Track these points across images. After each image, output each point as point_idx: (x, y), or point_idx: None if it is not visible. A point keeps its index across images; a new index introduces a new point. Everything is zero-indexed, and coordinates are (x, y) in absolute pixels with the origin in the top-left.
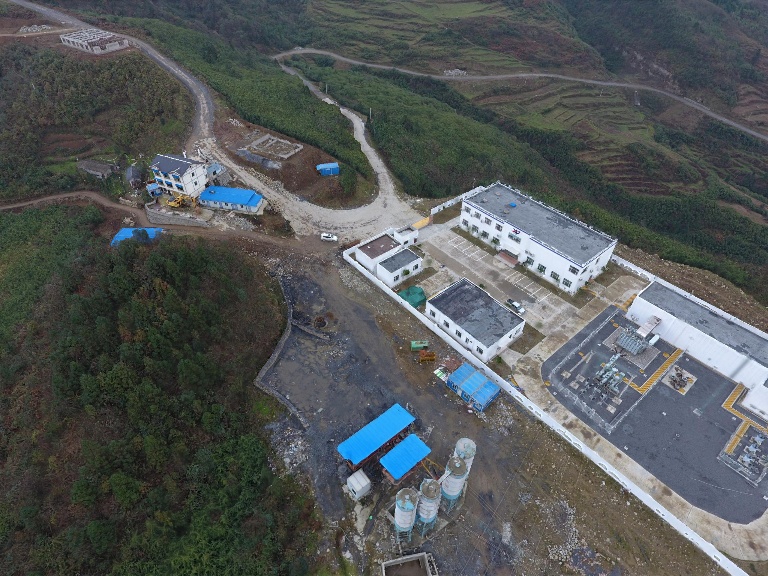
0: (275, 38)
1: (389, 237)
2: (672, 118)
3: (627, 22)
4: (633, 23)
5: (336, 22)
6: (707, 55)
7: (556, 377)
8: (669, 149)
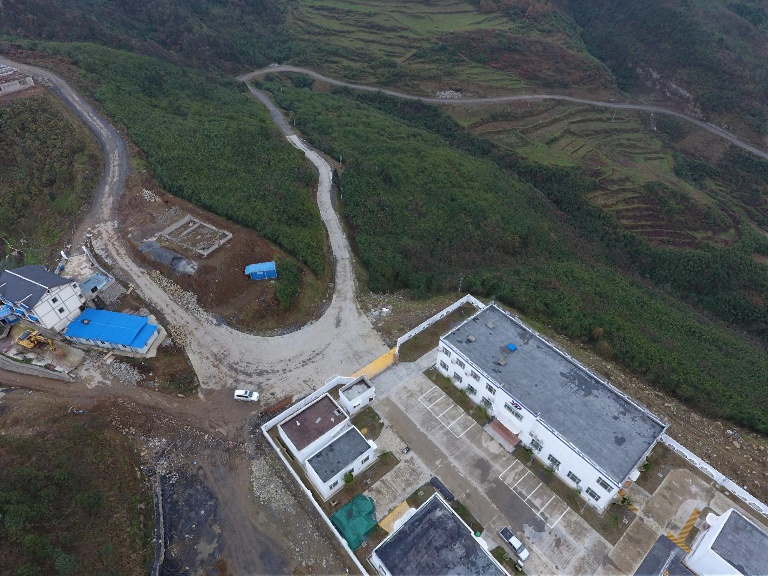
0: (247, 54)
1: (331, 401)
2: (693, 146)
3: (642, 35)
4: (648, 37)
5: (317, 35)
6: (734, 75)
7: None
8: (692, 186)
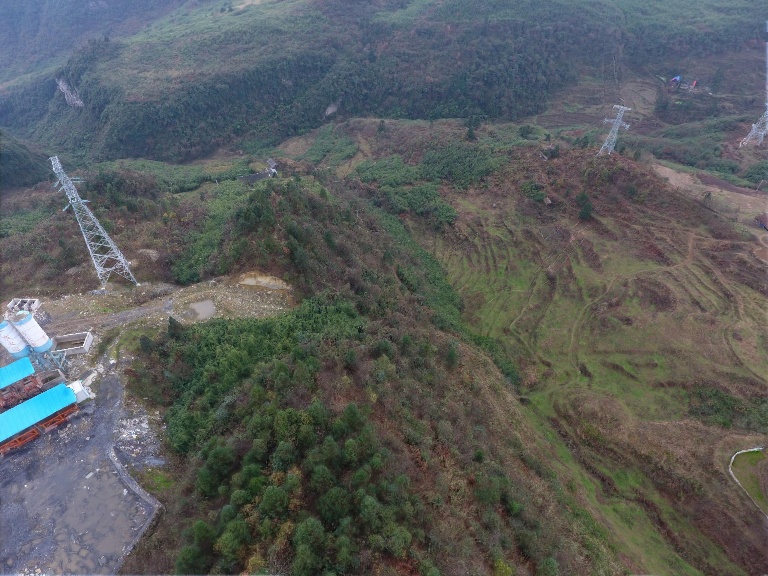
0: None
1: None
2: None
3: None
4: None
5: None
6: None
7: None
8: None
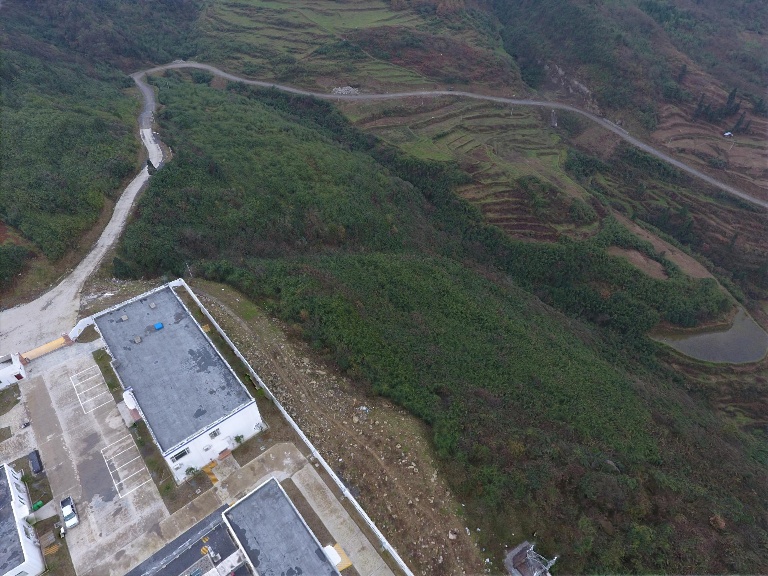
0: (149, 50)
1: None
2: (588, 142)
3: (550, 32)
4: (555, 34)
5: (226, 32)
6: (627, 72)
7: None
8: (573, 181)
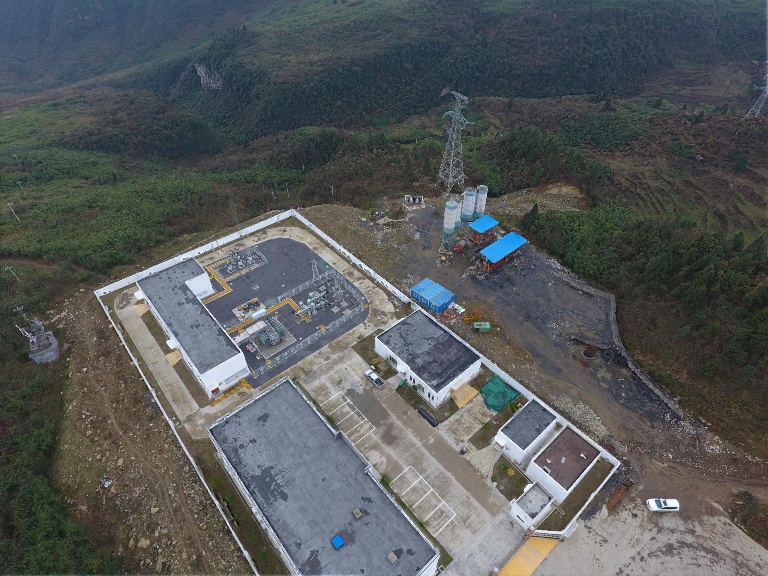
0: None
1: None
2: None
3: None
4: None
5: None
6: None
7: None
8: None
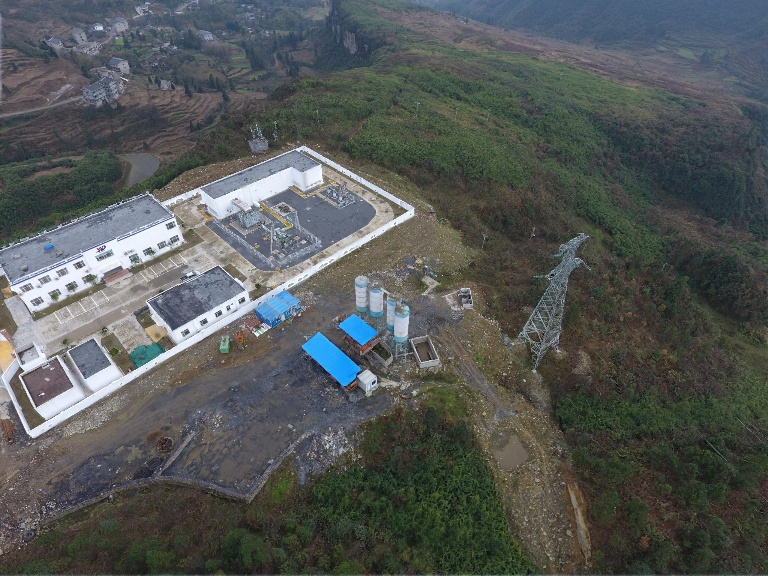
0: None
1: (30, 373)
2: None
3: None
4: None
5: None
6: None
7: (273, 264)
8: None
